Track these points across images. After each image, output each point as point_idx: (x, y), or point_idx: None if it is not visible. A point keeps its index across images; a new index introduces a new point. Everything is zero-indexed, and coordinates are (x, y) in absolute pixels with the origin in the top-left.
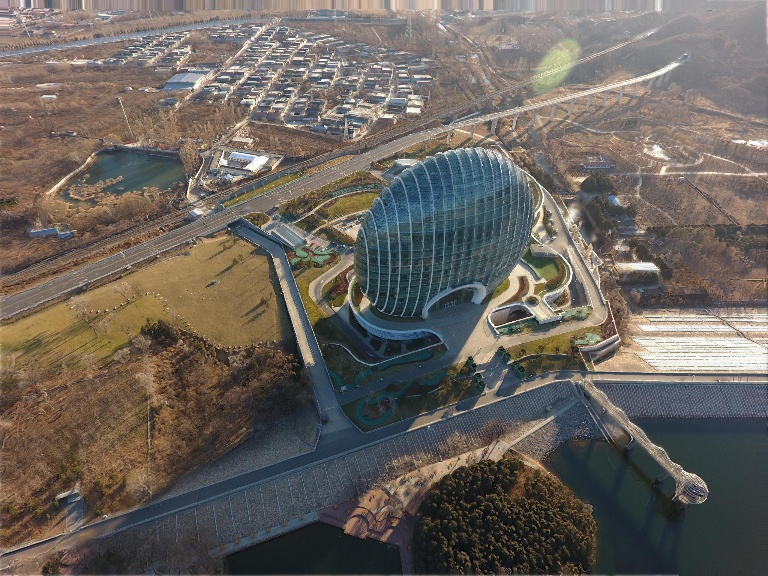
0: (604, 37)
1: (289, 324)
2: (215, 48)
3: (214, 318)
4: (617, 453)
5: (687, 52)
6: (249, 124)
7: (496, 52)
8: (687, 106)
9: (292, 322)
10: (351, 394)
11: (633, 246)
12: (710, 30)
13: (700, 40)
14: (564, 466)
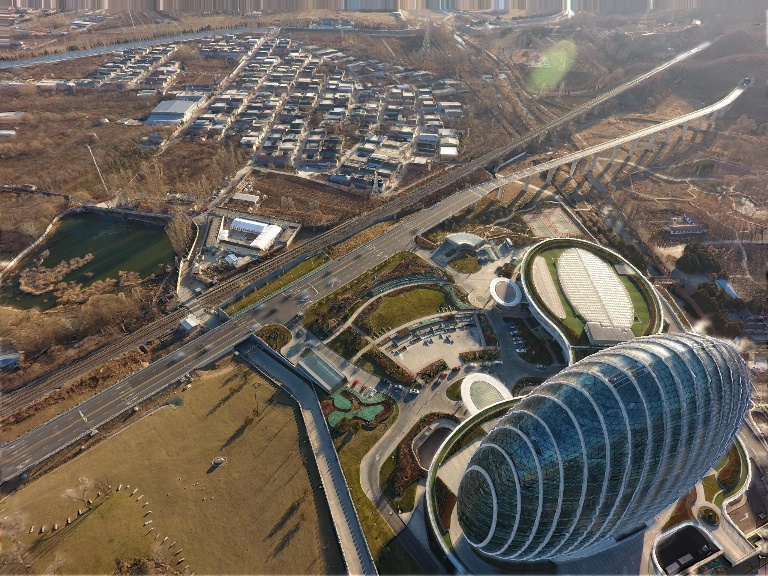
0: (645, 54)
1: (339, 557)
2: (207, 65)
3: (222, 543)
4: None
5: (749, 76)
6: (253, 172)
7: (526, 71)
8: (764, 144)
9: (344, 557)
10: None
11: None
12: (766, 49)
13: (763, 62)
14: None
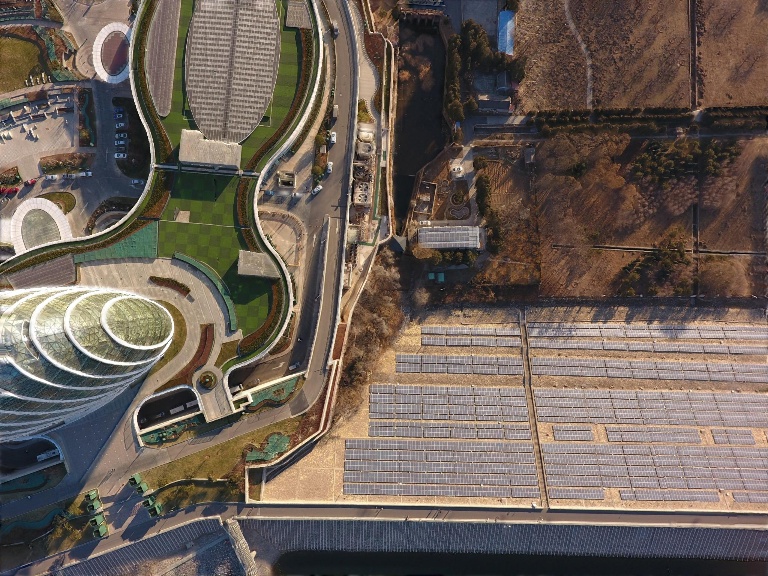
0: None
1: None
2: None
3: None
4: None
5: None
6: None
7: None
8: None
9: None
10: None
11: (478, 168)
12: None
13: None
14: None
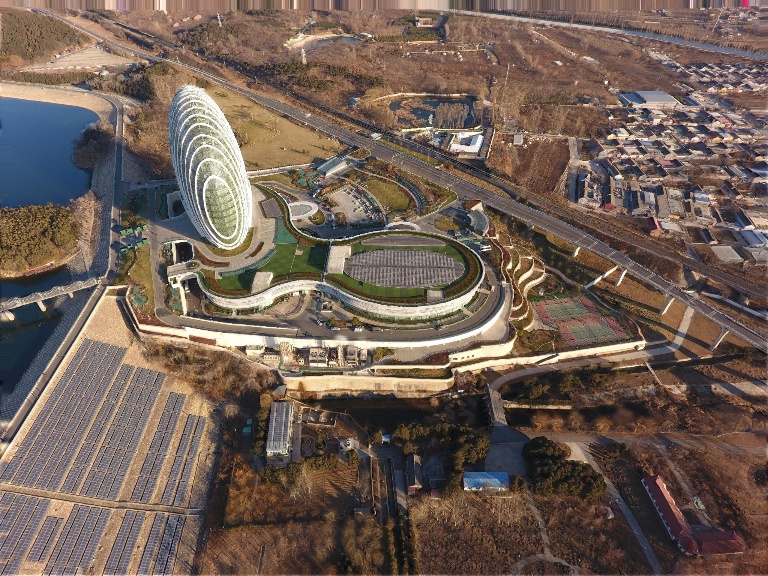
0: None
1: None
2: None
3: (248, 153)
4: (46, 302)
5: None
6: (563, 140)
7: None
8: None
9: None
10: (153, 190)
11: None
12: None
13: None
14: (56, 275)
